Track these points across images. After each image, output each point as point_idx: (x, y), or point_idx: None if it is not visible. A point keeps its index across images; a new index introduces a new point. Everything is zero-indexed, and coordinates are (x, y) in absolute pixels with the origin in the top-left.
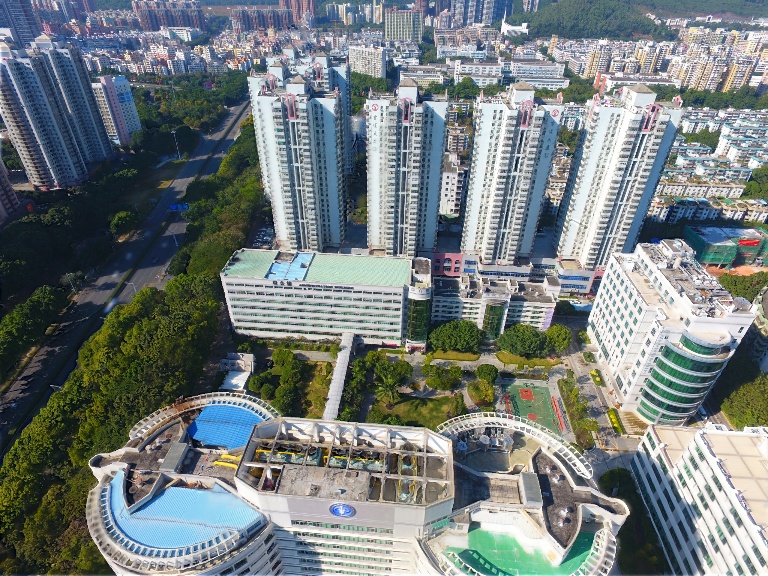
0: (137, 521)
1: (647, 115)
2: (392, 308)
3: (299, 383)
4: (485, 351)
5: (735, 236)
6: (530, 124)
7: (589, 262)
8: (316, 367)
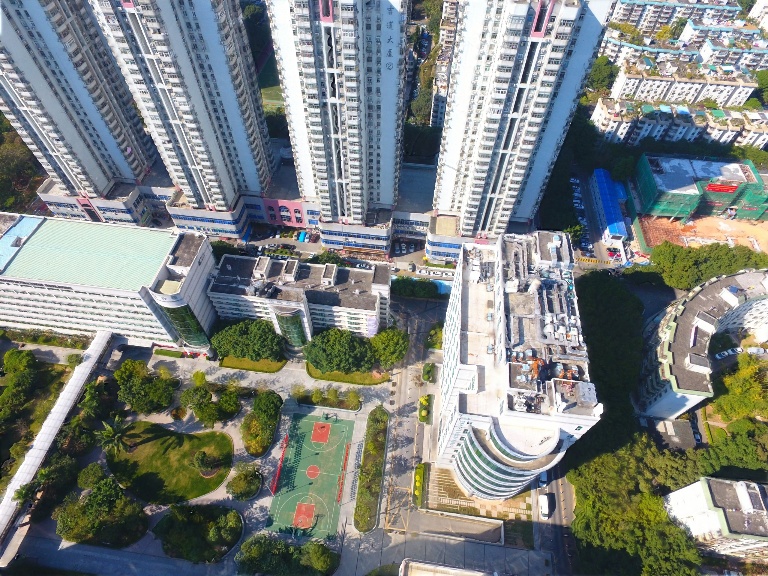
0: None
1: (538, 6)
2: (140, 312)
3: (30, 402)
4: (294, 356)
5: (705, 177)
6: (337, 16)
7: (466, 227)
8: (61, 376)
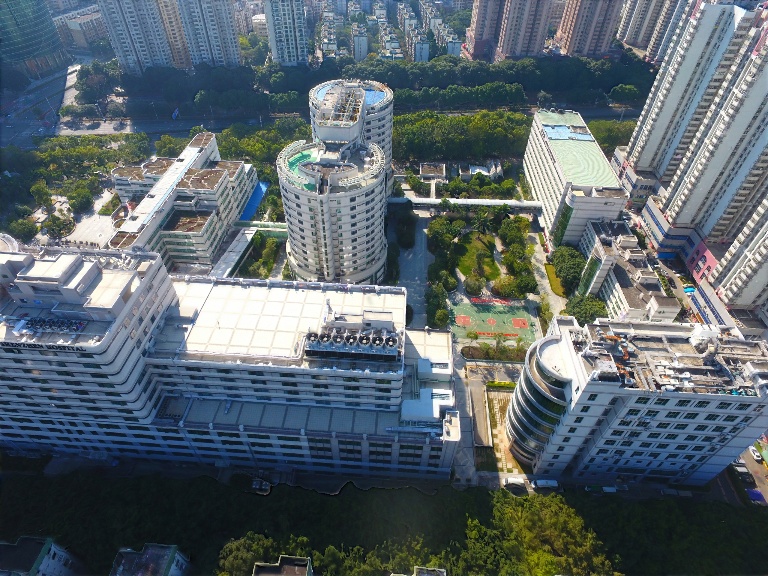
0: (328, 88)
1: None
2: None
3: None
4: None
5: None
6: None
7: None
8: None
